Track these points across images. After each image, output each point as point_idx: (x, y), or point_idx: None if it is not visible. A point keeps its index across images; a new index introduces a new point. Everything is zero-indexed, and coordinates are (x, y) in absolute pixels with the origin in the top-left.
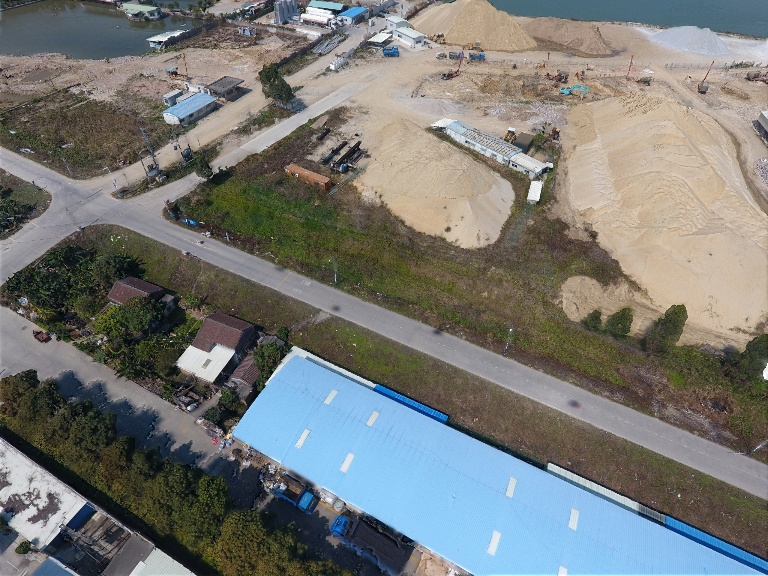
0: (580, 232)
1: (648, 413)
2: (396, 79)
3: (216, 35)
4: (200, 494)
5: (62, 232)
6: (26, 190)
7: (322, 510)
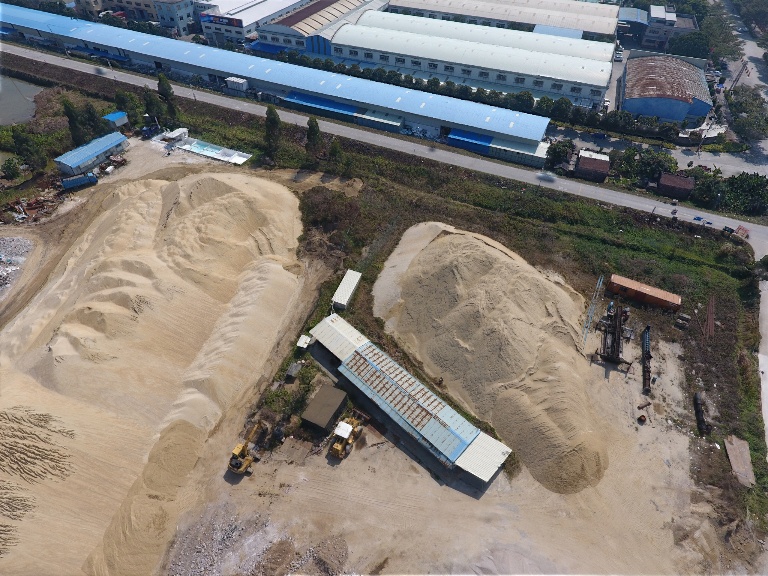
0: None
1: None
2: None
3: None
4: None
5: None
6: None
7: None
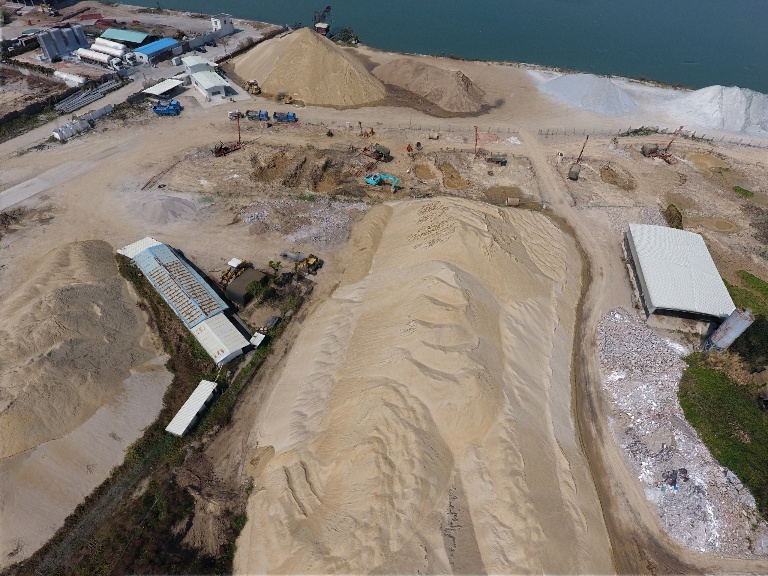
0: (210, 523)
1: None
2: (144, 155)
3: None
4: None
5: None
6: None
7: None
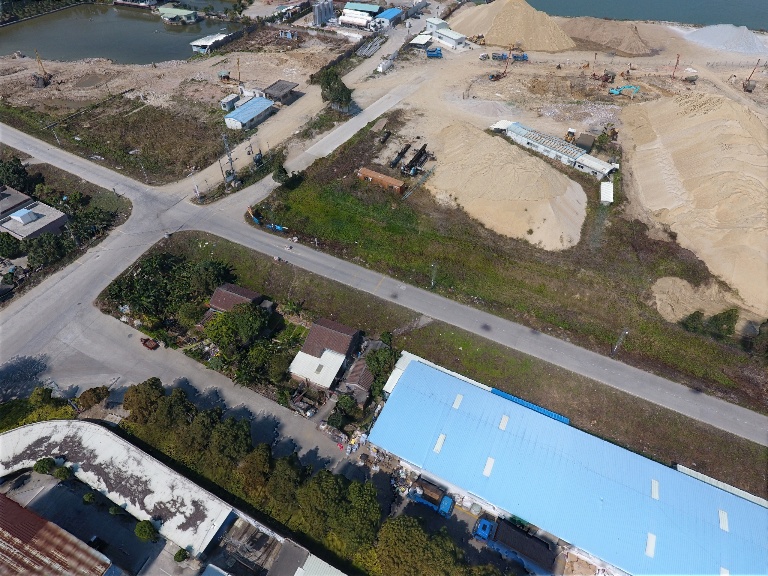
0: (660, 233)
1: (765, 413)
2: (444, 81)
3: (258, 38)
4: (354, 500)
5: (149, 239)
6: (105, 197)
7: (459, 514)
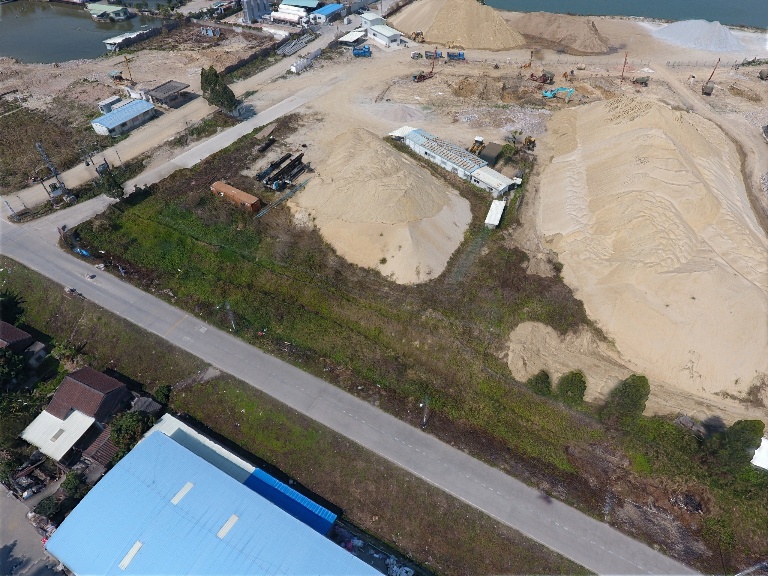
0: (542, 264)
1: (595, 516)
2: (362, 82)
3: (177, 36)
4: None
5: None
6: None
7: None
